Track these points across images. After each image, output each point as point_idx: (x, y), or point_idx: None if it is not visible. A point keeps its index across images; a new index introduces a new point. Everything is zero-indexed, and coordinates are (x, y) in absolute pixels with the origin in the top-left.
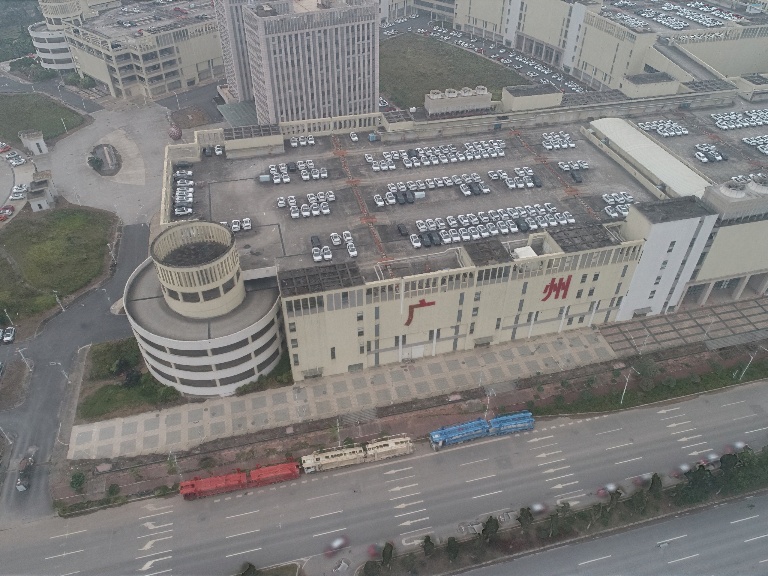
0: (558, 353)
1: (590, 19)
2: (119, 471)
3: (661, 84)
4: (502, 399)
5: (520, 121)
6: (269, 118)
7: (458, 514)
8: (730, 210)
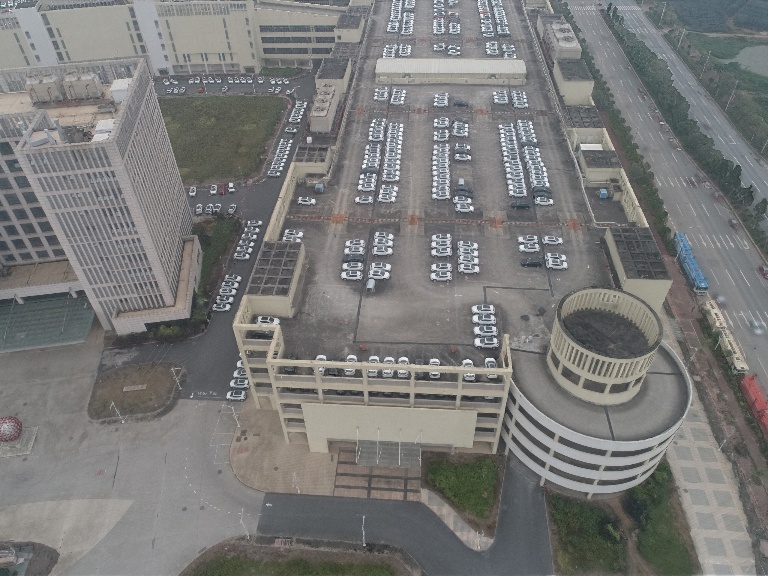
0: None
1: (167, 10)
2: (766, 533)
3: (361, 21)
4: None
5: None
6: (154, 275)
7: (765, 297)
8: None
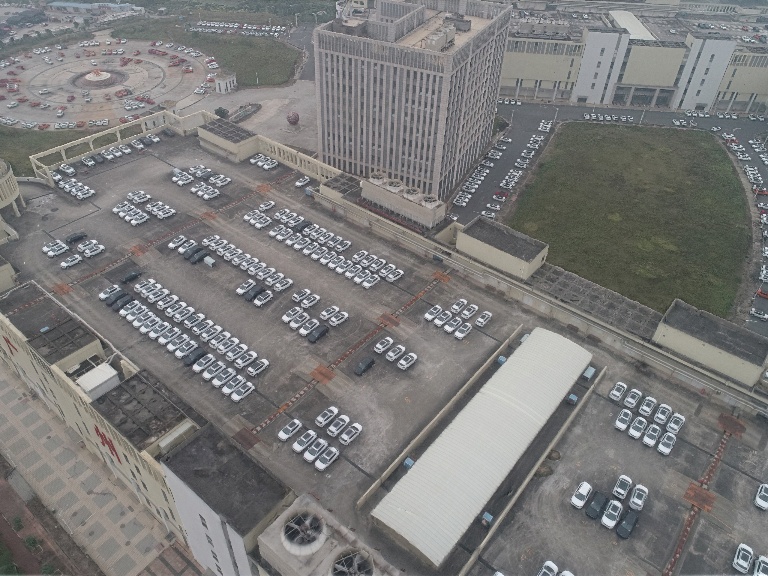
0: (102, 518)
1: None
2: None
3: (717, 351)
4: (5, 496)
5: (462, 267)
6: None
7: None
8: (266, 552)
